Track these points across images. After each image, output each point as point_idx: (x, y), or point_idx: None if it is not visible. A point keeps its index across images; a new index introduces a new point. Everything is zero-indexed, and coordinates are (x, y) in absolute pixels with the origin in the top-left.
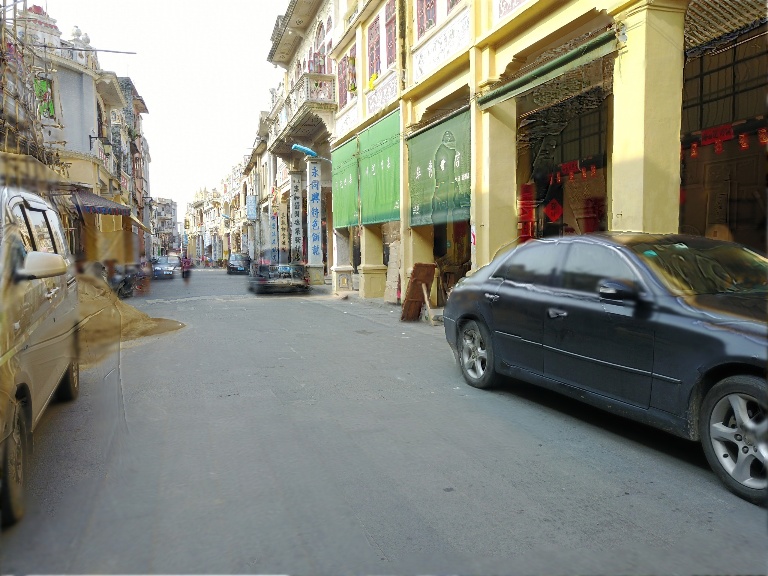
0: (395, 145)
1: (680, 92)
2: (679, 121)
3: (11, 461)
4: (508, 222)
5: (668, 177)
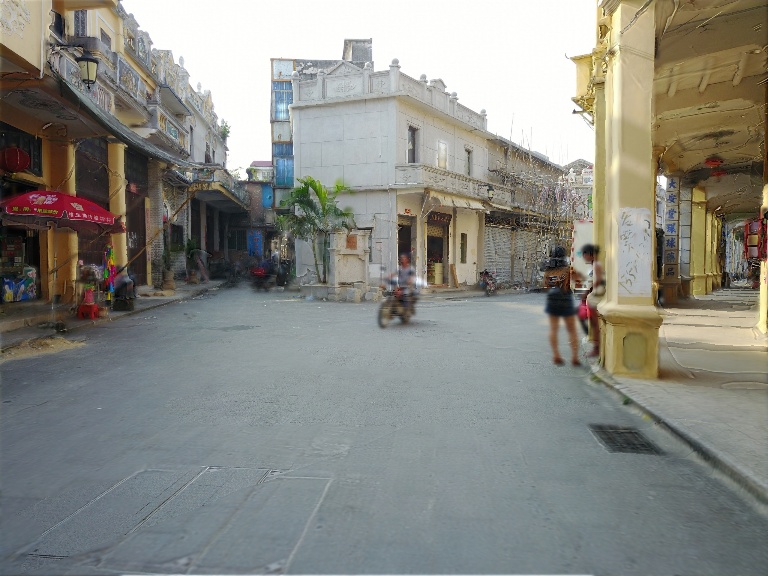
0: None
1: (710, 231)
2: (710, 238)
3: (567, 286)
4: (713, 258)
5: (707, 251)
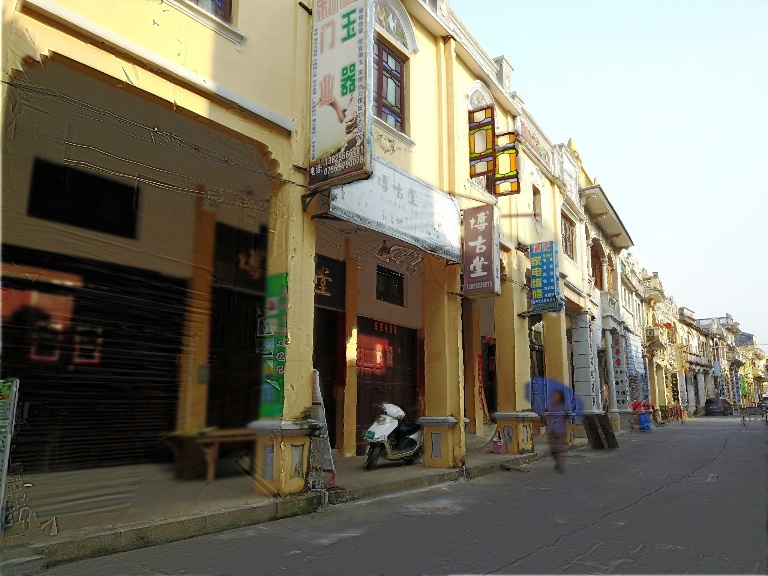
0: (745, 383)
1: None
2: None
3: None
4: None
5: None
